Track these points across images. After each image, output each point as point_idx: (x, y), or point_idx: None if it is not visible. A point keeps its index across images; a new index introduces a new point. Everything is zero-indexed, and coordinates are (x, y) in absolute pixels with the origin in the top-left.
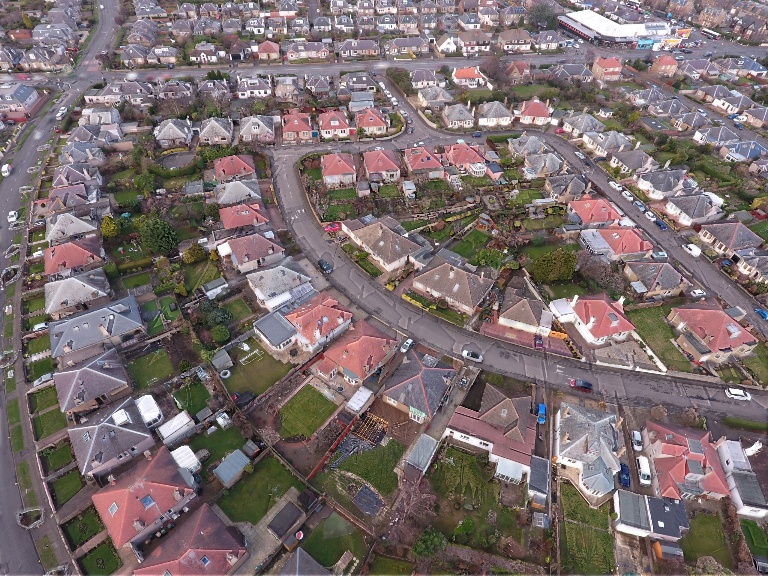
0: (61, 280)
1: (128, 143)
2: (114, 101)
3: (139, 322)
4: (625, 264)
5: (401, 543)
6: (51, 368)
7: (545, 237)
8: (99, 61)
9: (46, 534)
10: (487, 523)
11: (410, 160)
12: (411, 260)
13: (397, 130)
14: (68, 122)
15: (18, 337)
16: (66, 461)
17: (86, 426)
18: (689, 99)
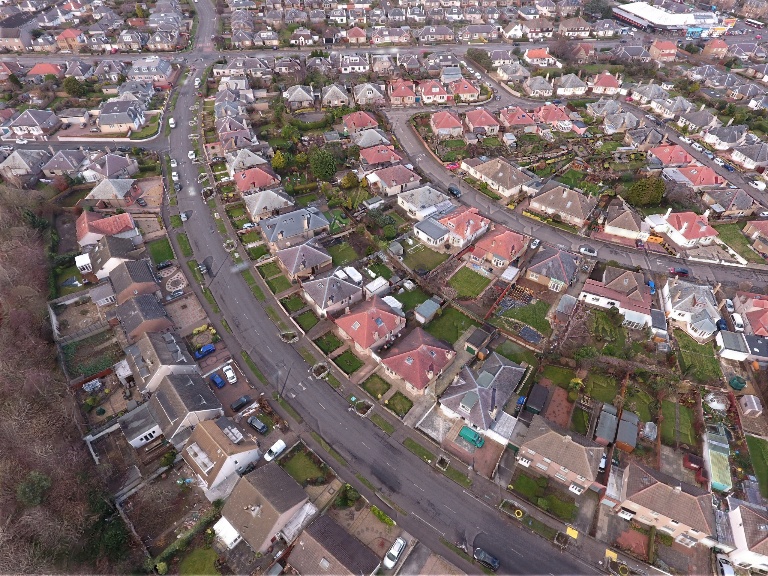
0: (261, 192)
1: (265, 104)
2: (239, 74)
3: (327, 221)
4: (703, 193)
5: (563, 356)
6: (265, 252)
7: (632, 175)
8: (214, 43)
9: (303, 346)
10: (623, 349)
11: (507, 118)
12: (524, 189)
13: (487, 97)
14: (207, 89)
15: (232, 233)
16: (300, 306)
17: (317, 279)
18: (740, 76)
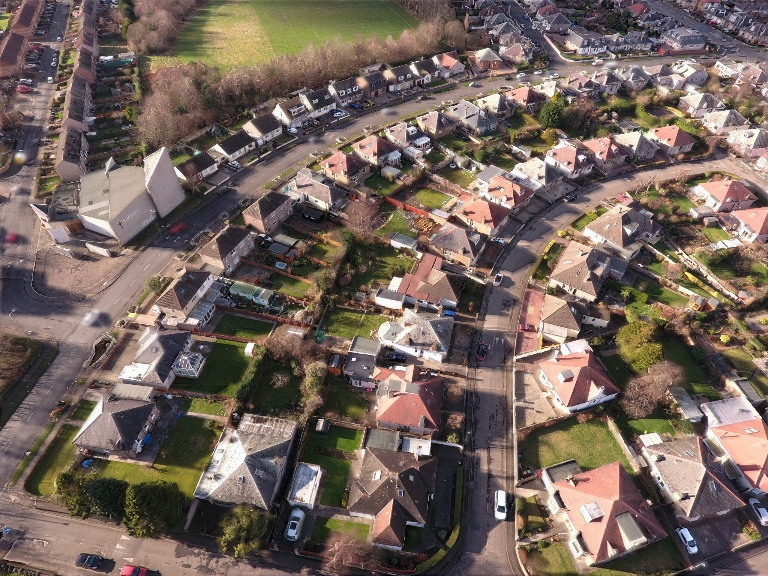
0: None
1: (666, 90)
2: (726, 73)
3: (478, 125)
4: None
5: None
6: None
7: None
8: None
9: (361, 134)
10: (361, 273)
11: None
12: None
13: None
14: None
15: None
16: None
17: (406, 122)
18: None
